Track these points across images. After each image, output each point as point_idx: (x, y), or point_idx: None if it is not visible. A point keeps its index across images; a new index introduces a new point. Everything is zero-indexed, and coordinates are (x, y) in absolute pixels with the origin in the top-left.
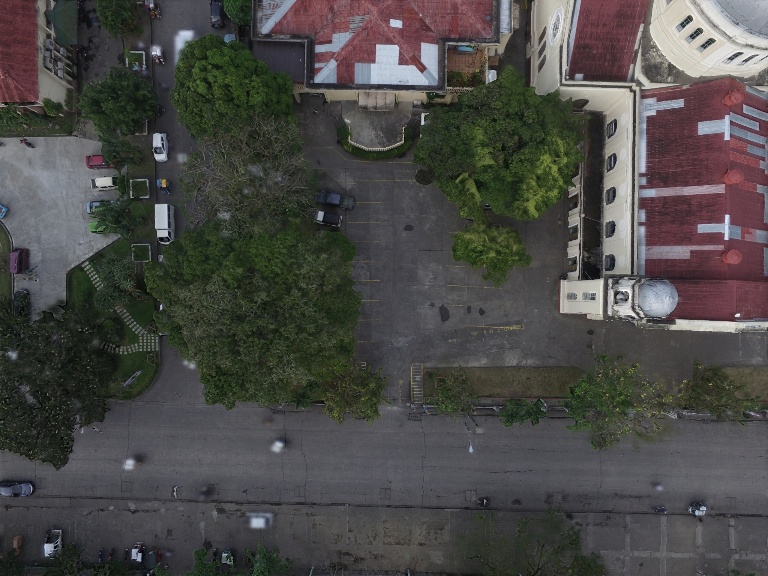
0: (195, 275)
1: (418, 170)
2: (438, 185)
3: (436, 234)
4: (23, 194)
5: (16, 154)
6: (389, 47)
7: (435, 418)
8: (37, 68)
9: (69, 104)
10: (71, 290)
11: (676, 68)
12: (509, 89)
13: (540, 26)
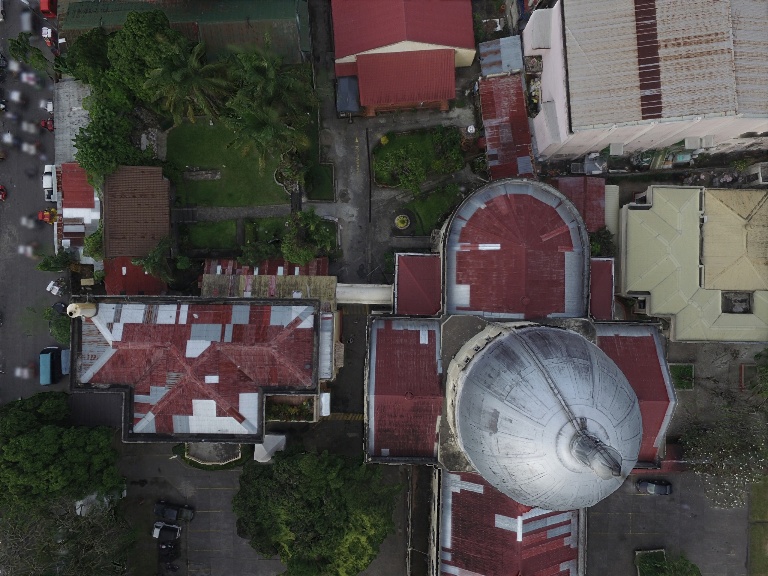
0: None
1: None
2: None
3: None
4: None
5: None
6: (205, 402)
7: None
8: None
9: None
10: None
11: None
12: (308, 477)
13: None
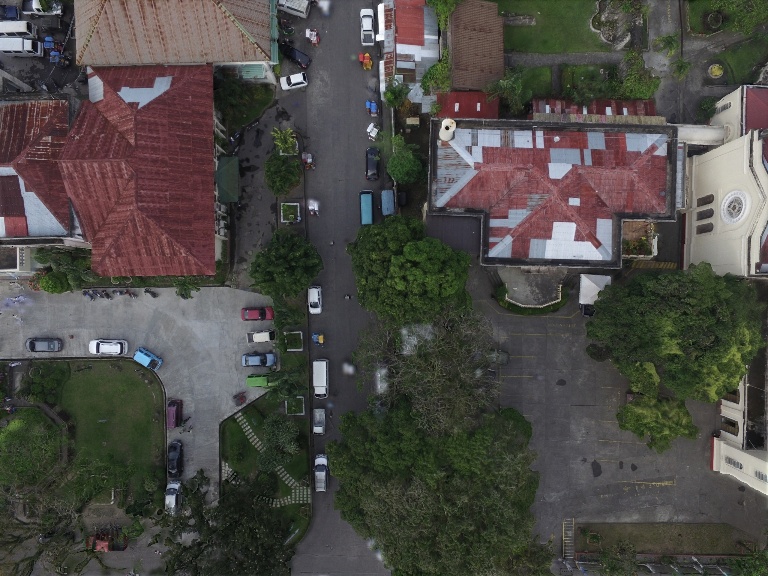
0: (386, 467)
1: (571, 325)
2: (617, 366)
3: (589, 389)
4: (176, 344)
5: (169, 304)
6: (566, 224)
7: (586, 573)
8: (214, 241)
9: (224, 256)
10: (224, 441)
11: None
12: (702, 284)
13: (702, 189)
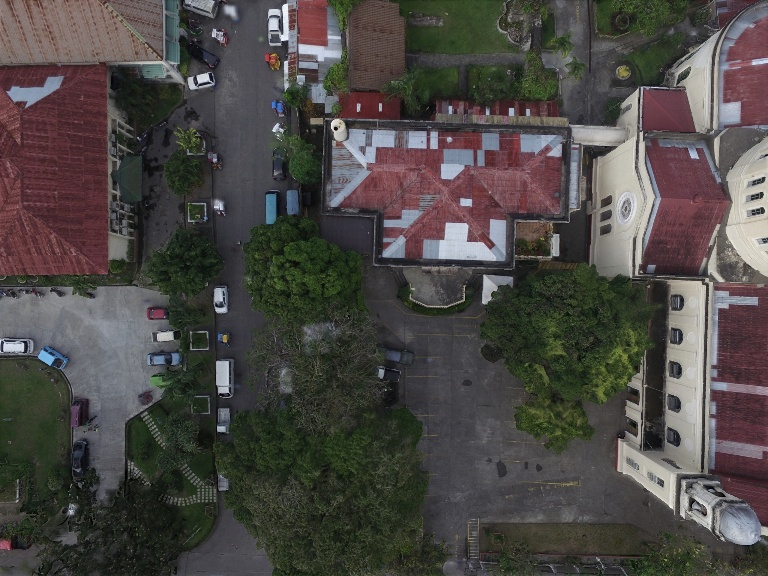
0: (268, 466)
1: (477, 325)
2: (506, 367)
3: (494, 389)
4: (83, 343)
5: (76, 303)
6: (458, 225)
7: (491, 574)
8: (107, 241)
9: (130, 256)
10: (130, 440)
11: (751, 268)
12: (584, 285)
13: (604, 191)
